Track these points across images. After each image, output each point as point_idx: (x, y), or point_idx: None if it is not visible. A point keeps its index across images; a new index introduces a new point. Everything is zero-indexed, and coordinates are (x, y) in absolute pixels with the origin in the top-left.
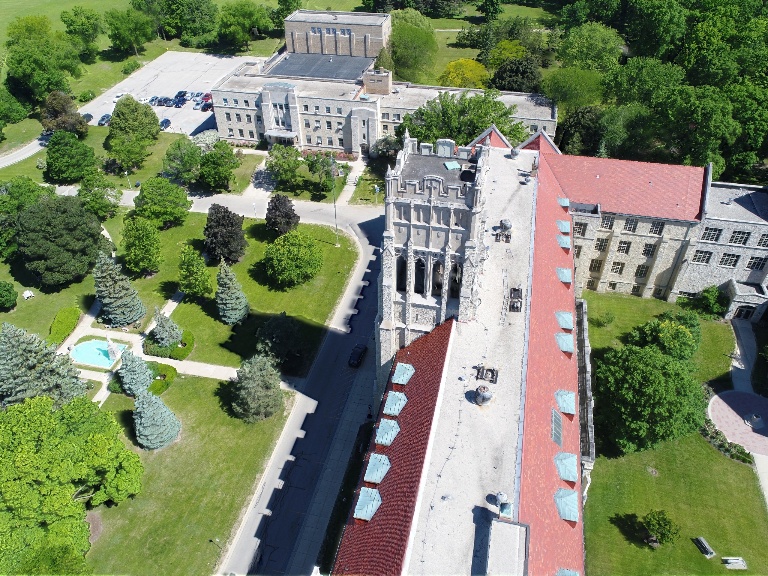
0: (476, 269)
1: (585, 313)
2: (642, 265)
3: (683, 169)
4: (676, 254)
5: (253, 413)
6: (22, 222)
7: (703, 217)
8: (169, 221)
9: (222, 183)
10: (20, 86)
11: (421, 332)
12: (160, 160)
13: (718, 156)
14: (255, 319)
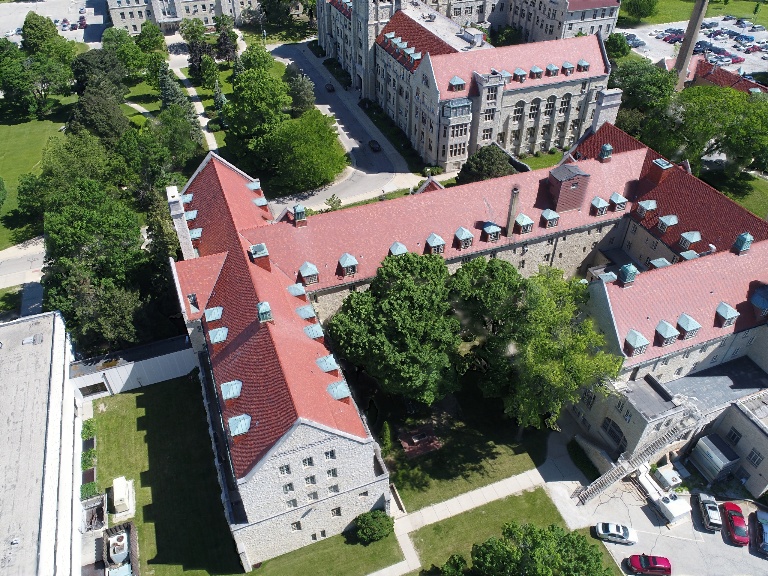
0: None
1: None
2: None
3: None
4: (446, 13)
5: None
6: (86, 61)
7: None
8: (137, 79)
9: None
10: None
11: (385, 23)
12: None
13: None
14: None
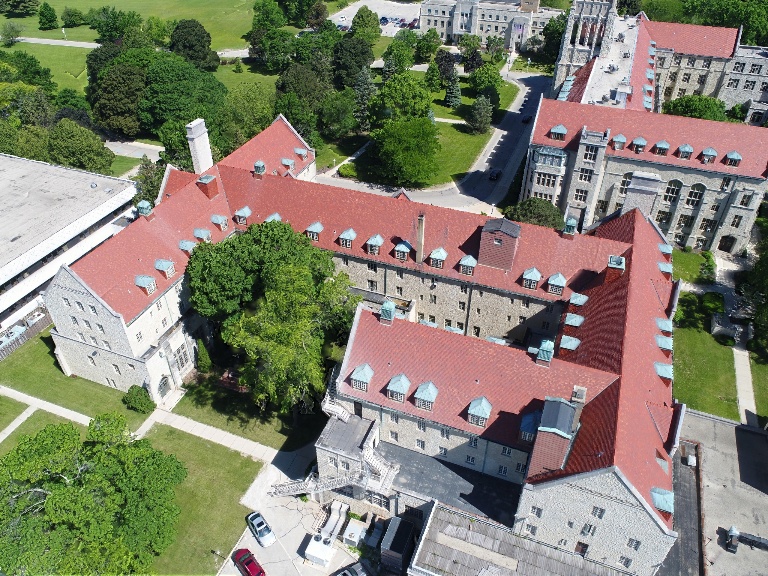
0: (612, 25)
1: (660, 86)
2: (697, 90)
3: (725, 29)
4: (717, 82)
5: (475, 130)
6: (342, 44)
7: (734, 55)
8: None
9: (425, 59)
10: (282, 6)
11: (578, 67)
12: (382, 48)
13: (754, 43)
14: (464, 107)
